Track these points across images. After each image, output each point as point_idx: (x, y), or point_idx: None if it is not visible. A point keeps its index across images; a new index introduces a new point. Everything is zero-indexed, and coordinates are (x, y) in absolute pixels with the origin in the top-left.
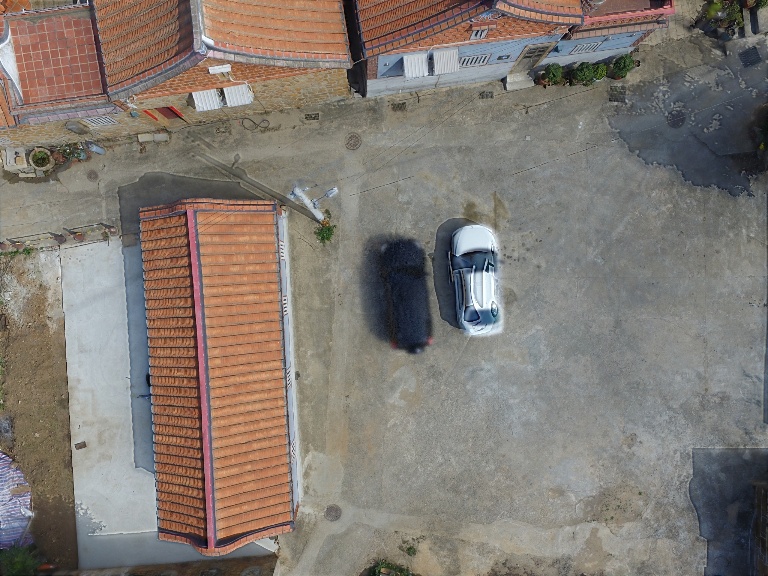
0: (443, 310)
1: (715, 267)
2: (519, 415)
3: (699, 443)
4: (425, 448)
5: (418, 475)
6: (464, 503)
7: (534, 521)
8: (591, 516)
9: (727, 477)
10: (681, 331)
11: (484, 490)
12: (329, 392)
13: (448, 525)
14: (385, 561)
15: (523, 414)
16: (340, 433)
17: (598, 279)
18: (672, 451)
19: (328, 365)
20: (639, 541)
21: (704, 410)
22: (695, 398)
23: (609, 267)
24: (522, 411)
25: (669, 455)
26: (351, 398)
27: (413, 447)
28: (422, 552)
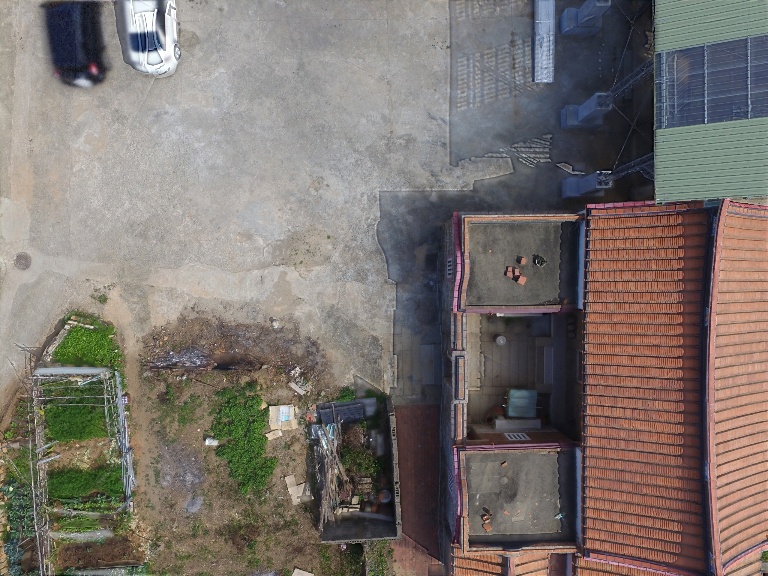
0: (126, 54)
1: (397, 9)
2: (205, 159)
3: (385, 186)
4: (112, 193)
5: (106, 221)
6: (152, 248)
7: (222, 265)
8: (280, 260)
9: (414, 220)
10: (365, 73)
11: (172, 235)
12: (12, 136)
13: (138, 271)
14: (77, 310)
15: (209, 158)
16: (25, 178)
17: (280, 22)
18: (359, 194)
19: (11, 109)
20: (328, 285)
21: (390, 153)
22: (381, 141)
23: (291, 10)
24: (208, 155)
25: (356, 198)
26: (35, 142)
27: (100, 192)
28: (113, 299)
